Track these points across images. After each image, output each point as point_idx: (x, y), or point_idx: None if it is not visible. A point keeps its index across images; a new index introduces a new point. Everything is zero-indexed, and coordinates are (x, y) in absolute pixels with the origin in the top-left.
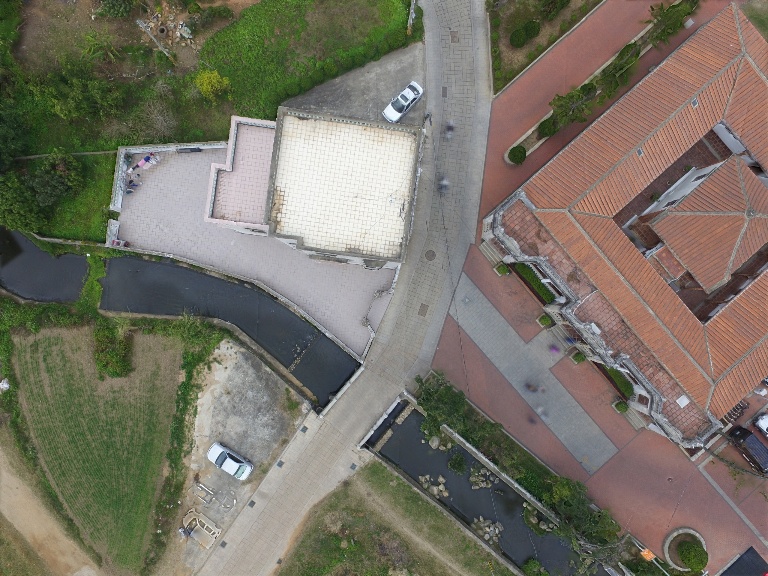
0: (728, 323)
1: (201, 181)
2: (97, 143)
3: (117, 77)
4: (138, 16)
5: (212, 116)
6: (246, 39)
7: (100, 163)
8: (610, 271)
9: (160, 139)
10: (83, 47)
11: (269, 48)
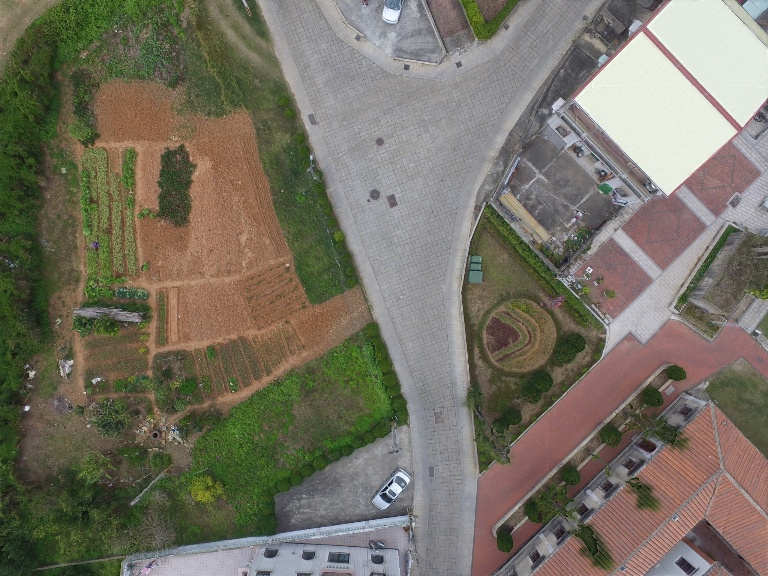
0: None
1: (202, 575)
2: (101, 548)
3: (115, 483)
4: (131, 420)
5: (208, 512)
6: (236, 438)
7: (105, 567)
8: None
9: (160, 552)
10: (81, 469)
11: (259, 443)
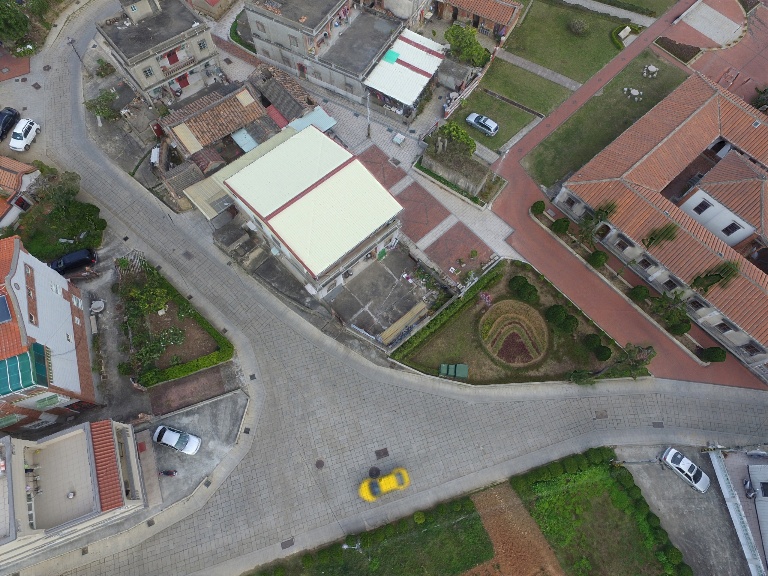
0: None
1: None
2: None
3: None
4: None
5: None
6: None
7: None
8: None
9: None
10: None
11: None
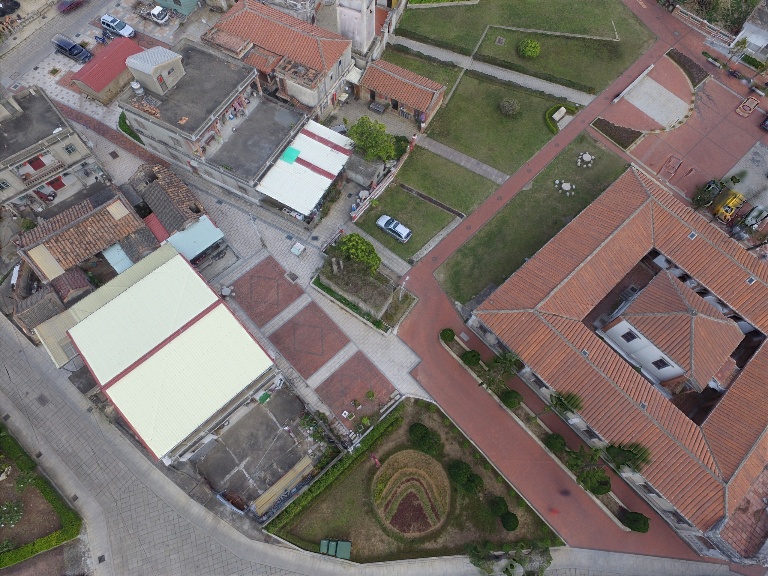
0: (762, 317)
1: None
2: None
3: None
4: None
5: None
6: None
7: None
8: (766, 435)
9: None
10: None
11: None
